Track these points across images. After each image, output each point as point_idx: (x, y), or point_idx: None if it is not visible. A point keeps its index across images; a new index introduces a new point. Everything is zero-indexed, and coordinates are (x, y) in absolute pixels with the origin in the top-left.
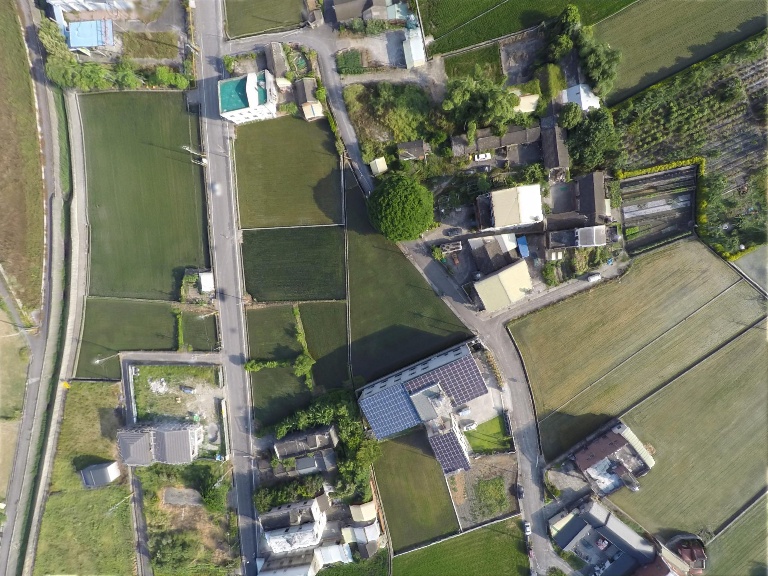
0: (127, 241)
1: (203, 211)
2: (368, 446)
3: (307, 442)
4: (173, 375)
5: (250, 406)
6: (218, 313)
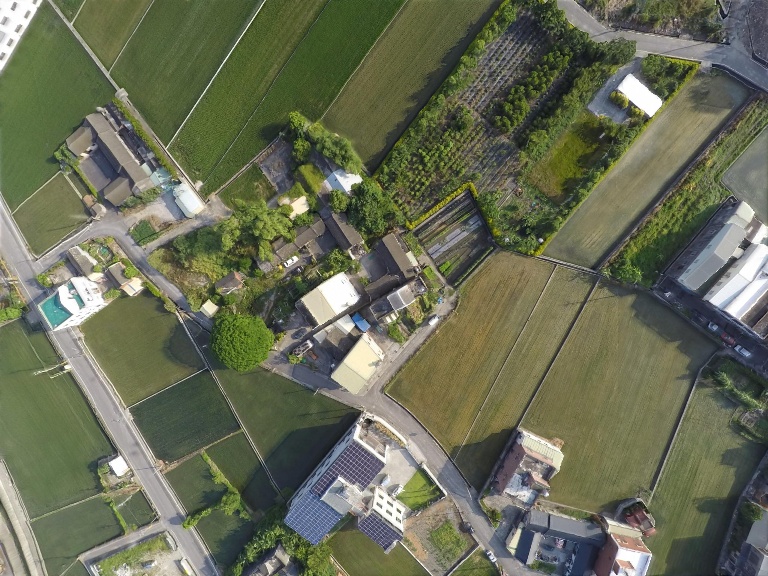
0: (39, 460)
1: (88, 407)
2: (314, 552)
3: (261, 572)
4: (131, 557)
5: (208, 554)
6: (142, 488)
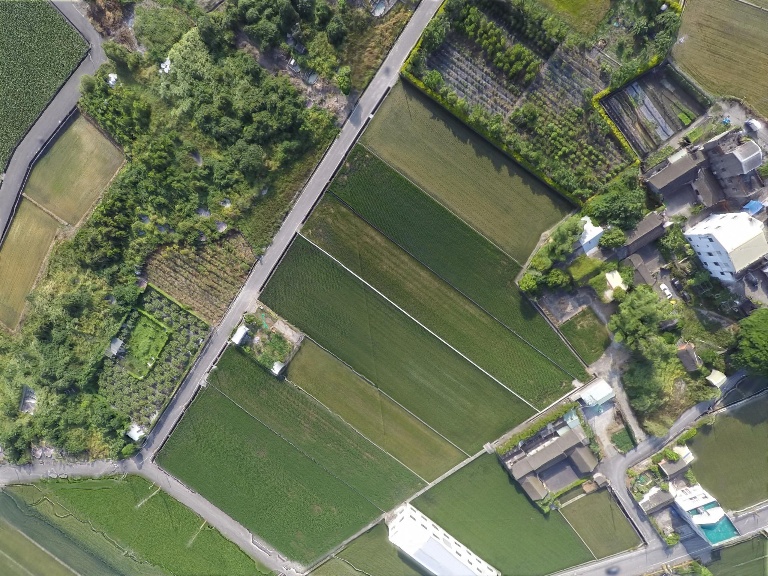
0: None
1: None
2: None
3: None
4: None
5: None
6: None
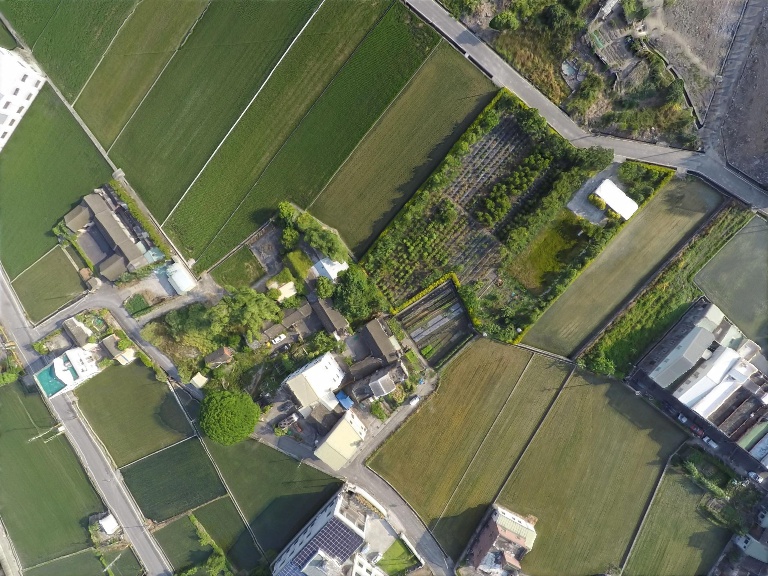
0: (32, 514)
1: (81, 466)
2: None
3: None
4: None
5: None
6: (131, 544)
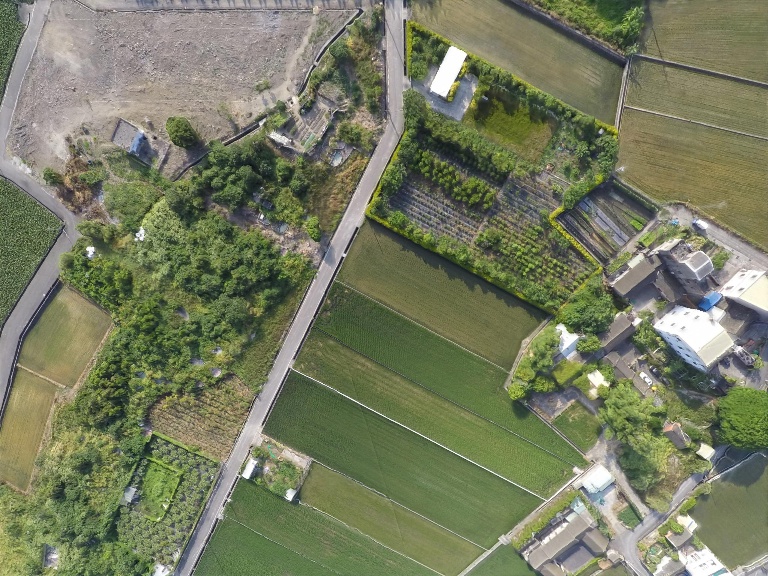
0: None
1: None
2: None
3: None
4: None
5: None
6: None
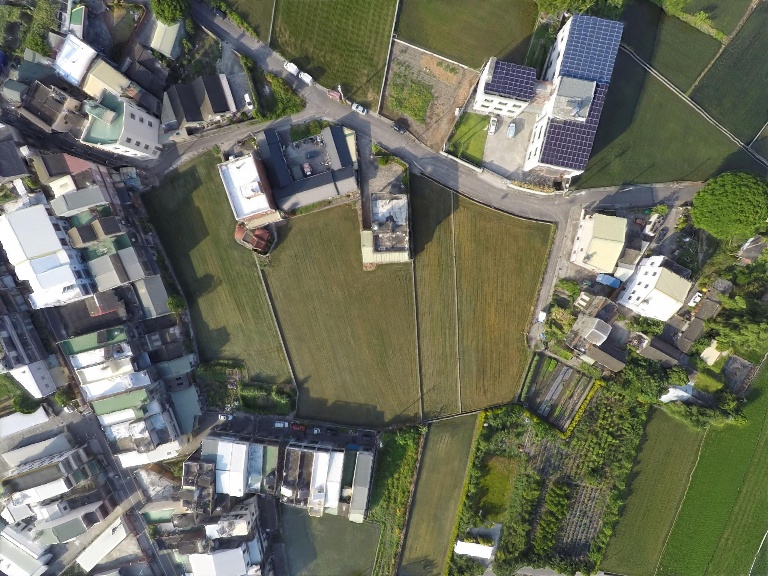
0: None
1: None
2: None
3: None
4: None
5: None
6: None
